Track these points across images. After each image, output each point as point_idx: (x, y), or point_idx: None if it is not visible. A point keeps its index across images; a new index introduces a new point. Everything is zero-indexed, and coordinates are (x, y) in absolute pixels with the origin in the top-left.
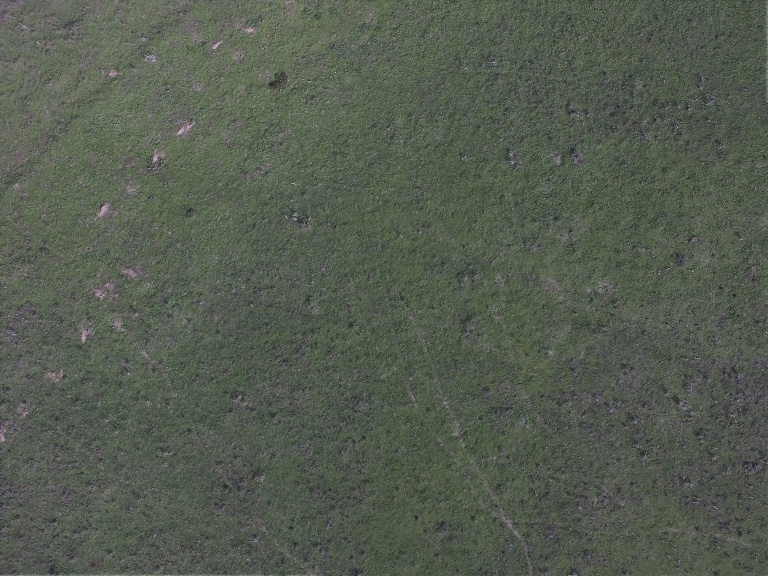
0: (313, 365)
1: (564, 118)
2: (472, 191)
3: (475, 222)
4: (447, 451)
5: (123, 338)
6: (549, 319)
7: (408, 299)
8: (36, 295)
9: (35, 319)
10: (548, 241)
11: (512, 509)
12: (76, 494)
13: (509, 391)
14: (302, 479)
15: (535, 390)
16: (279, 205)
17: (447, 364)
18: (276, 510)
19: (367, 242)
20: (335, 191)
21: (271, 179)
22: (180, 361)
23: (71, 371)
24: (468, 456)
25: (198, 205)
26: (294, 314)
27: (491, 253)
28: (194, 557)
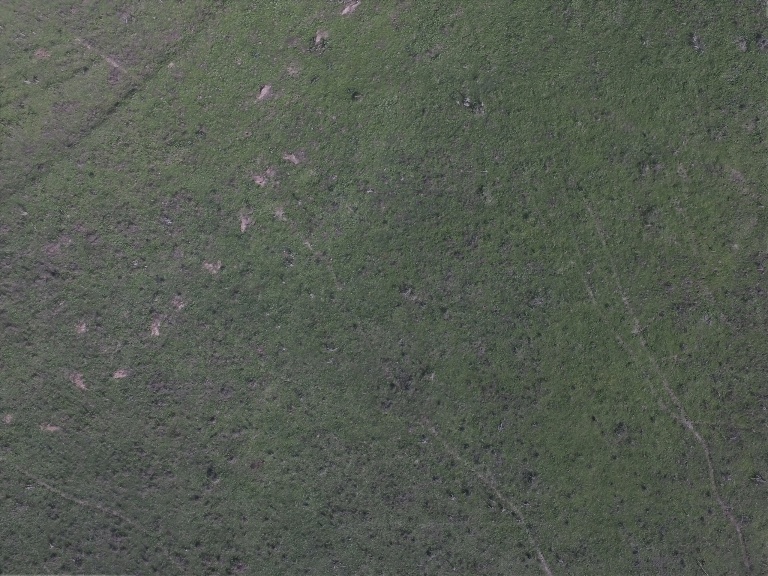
0: (486, 258)
1: (750, 3)
2: (654, 77)
3: (657, 109)
4: (626, 349)
5: (285, 228)
6: (734, 211)
7: (586, 189)
8: (192, 182)
9: (191, 207)
10: (734, 130)
11: (693, 410)
12: (235, 391)
13: (691, 286)
14: (474, 377)
15: (719, 285)
16: (449, 90)
17: (626, 258)
18: (446, 410)
19: (543, 130)
20: (509, 76)
21: (441, 63)
22: (345, 253)
23: (229, 262)
24: (648, 354)
25: (364, 89)
26: (466, 204)
27: (673, 142)
28: (359, 459)
